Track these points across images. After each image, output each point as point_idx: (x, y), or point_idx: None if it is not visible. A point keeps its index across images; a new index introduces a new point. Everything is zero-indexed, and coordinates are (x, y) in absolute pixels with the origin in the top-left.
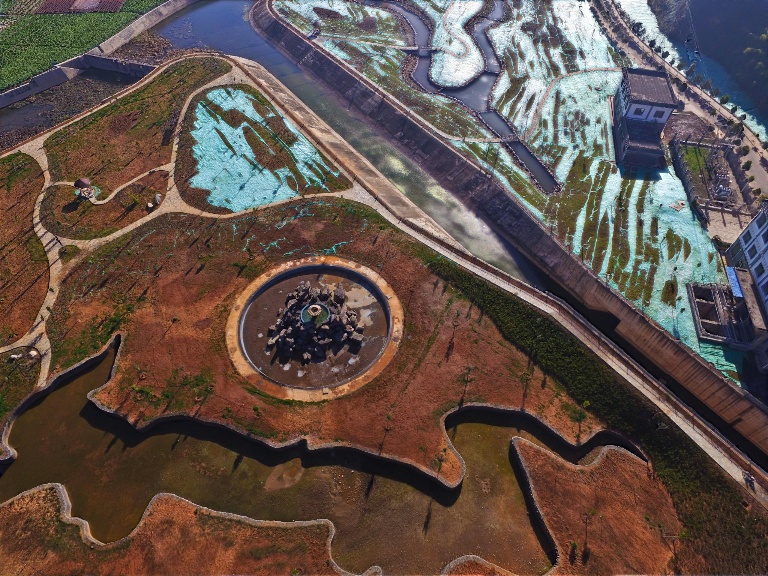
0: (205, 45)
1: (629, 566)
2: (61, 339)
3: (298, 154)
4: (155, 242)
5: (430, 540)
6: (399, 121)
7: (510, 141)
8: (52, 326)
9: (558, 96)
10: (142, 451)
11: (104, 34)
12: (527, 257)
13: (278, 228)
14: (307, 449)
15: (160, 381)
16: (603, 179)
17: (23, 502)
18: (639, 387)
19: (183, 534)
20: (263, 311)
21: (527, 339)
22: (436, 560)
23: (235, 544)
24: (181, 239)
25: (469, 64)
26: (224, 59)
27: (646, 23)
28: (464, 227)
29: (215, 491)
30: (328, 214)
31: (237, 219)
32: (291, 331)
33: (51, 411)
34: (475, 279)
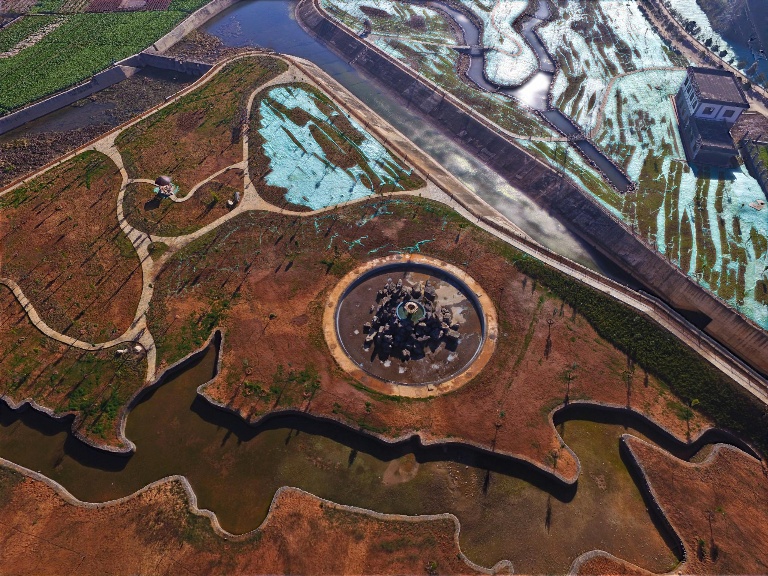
0: (256, 44)
1: (761, 563)
2: (163, 334)
3: (368, 152)
4: (241, 239)
5: (554, 535)
6: (462, 120)
7: (577, 140)
8: (153, 322)
9: (619, 95)
10: (257, 445)
11: (156, 33)
12: (606, 256)
13: (359, 226)
14: (421, 444)
15: (266, 376)
16: (677, 178)
17: (151, 494)
18: (746, 386)
19: (312, 527)
20: (356, 308)
21: (624, 337)
22: (563, 555)
23: (365, 537)
24: (266, 236)
25: (523, 63)
26: (279, 58)
27: (697, 22)
28: (539, 226)
29: (335, 485)
30: (407, 212)
31: (318, 217)
32: (389, 328)
33: (162, 405)
34: (564, 277)
